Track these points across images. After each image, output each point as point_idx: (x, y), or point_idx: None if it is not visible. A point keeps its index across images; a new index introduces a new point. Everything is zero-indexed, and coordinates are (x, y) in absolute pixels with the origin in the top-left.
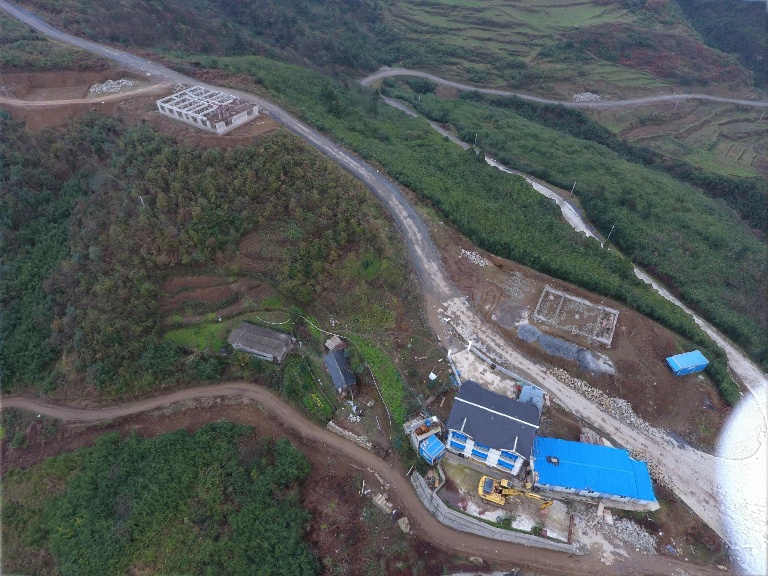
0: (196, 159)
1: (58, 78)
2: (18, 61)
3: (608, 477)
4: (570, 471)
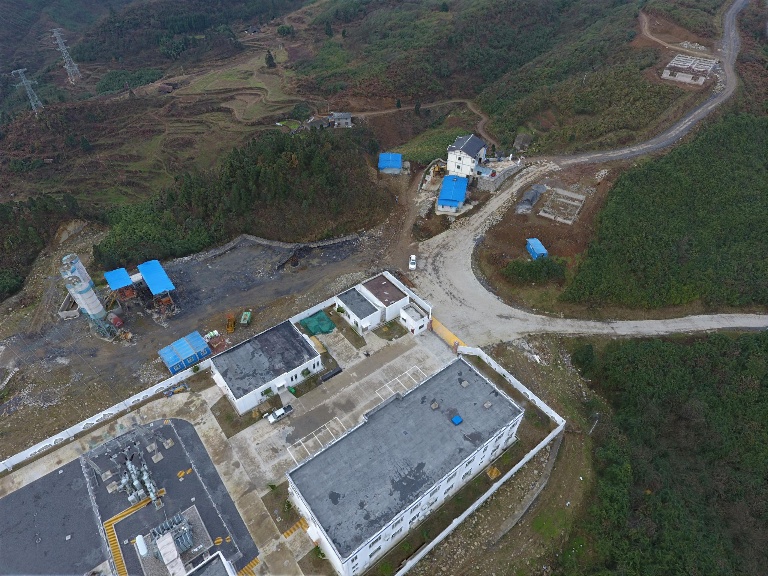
0: (628, 76)
1: (680, 32)
2: (677, 16)
3: (448, 192)
4: (450, 183)
